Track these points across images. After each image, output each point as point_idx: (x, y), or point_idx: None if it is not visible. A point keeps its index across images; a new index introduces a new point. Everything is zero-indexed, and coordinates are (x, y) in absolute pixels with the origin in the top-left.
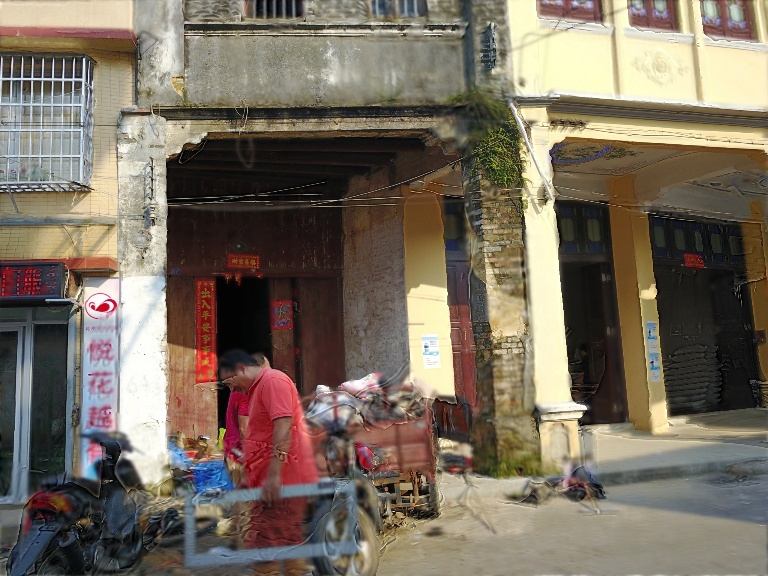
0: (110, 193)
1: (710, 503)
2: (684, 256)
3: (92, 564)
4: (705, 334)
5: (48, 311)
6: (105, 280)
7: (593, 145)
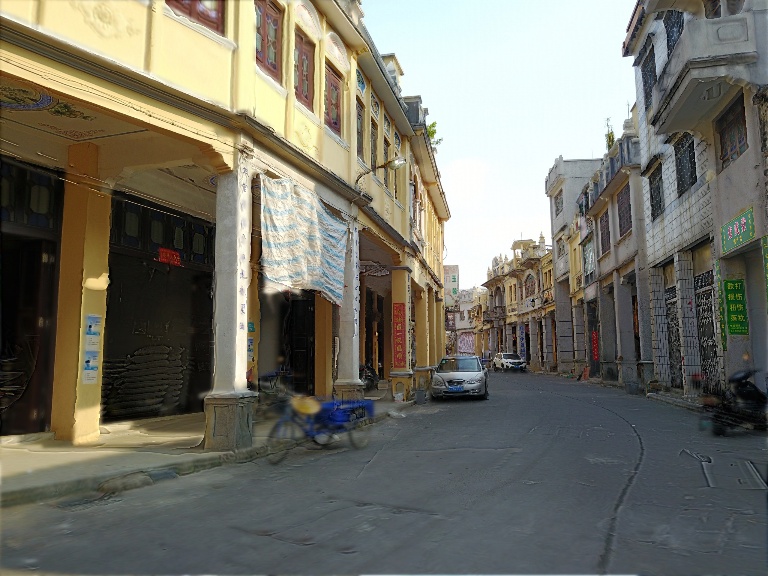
0: None
1: (16, 539)
2: (159, 250)
3: None
4: (172, 335)
5: None
6: None
7: (23, 87)
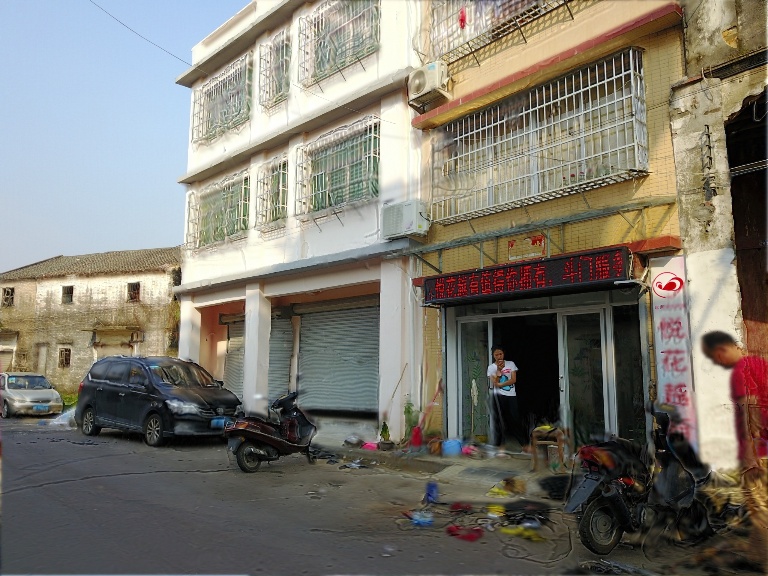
0: (668, 172)
1: None
2: None
3: (639, 522)
4: None
5: (621, 293)
6: (669, 259)
7: None
